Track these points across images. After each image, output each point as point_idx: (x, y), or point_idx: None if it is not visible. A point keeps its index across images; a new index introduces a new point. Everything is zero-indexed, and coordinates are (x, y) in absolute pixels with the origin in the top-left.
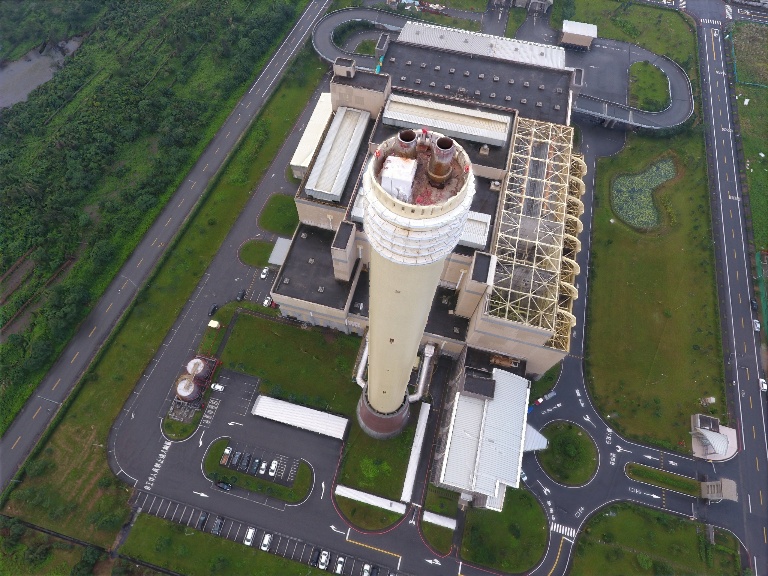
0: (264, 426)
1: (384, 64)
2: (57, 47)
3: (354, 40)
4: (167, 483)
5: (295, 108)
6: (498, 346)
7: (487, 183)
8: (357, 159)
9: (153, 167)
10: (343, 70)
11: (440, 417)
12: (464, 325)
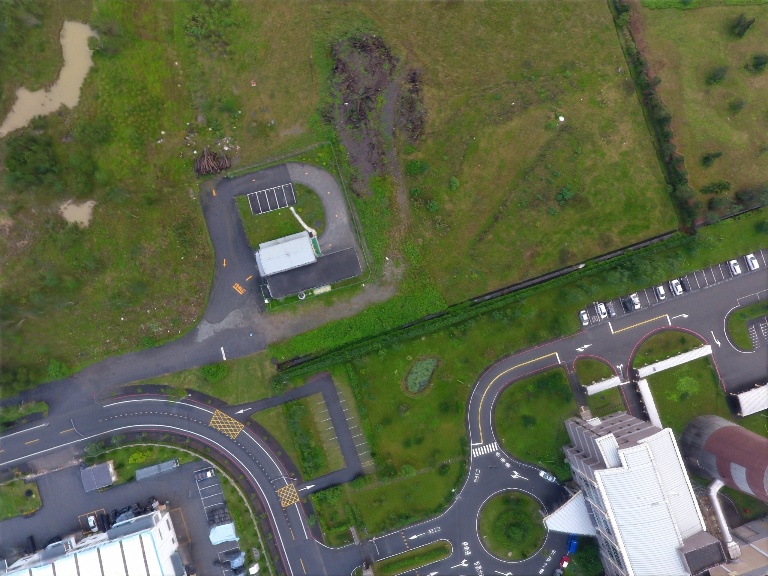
0: None
1: None
2: None
3: None
4: None
5: None
6: None
7: None
8: None
9: None
10: None
11: None
12: None
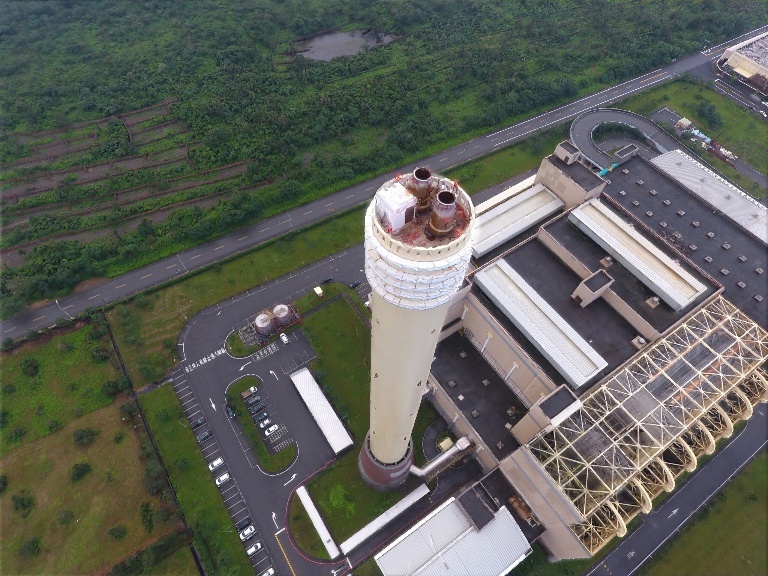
0: (291, 393)
1: (614, 171)
2: (377, 36)
3: (615, 142)
4: (200, 377)
5: (514, 169)
6: (526, 490)
7: (633, 334)
8: (522, 235)
9: (371, 152)
10: (564, 153)
11: (430, 510)
12: (511, 447)
